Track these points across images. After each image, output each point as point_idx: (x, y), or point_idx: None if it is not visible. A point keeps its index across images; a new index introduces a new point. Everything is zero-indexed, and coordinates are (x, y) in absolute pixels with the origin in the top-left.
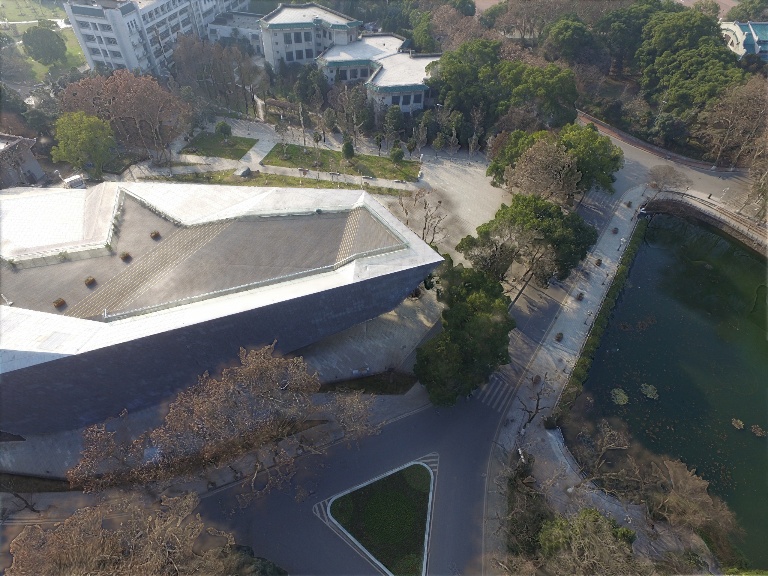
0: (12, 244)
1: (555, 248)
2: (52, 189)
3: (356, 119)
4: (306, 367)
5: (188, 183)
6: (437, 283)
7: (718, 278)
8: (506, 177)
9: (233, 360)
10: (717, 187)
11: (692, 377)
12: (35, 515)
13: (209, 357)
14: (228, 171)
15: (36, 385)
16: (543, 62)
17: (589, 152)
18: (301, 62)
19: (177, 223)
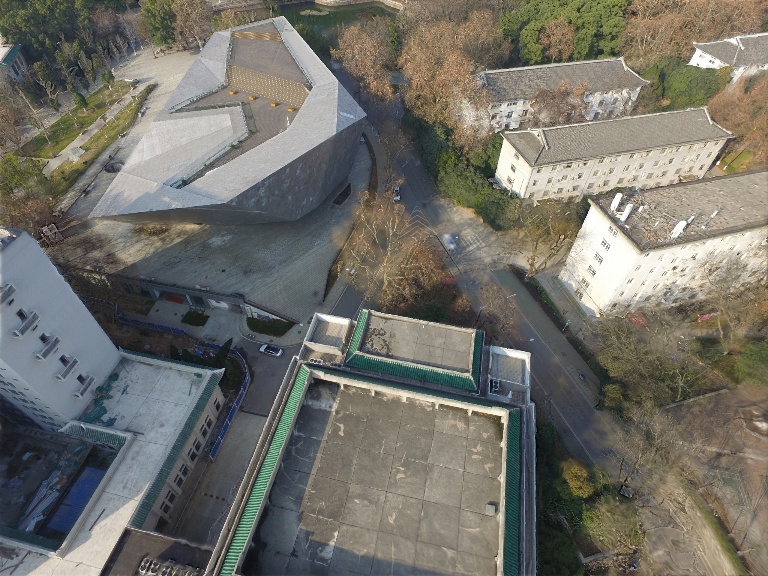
0: (227, 140)
1: None
2: (111, 188)
3: None
4: None
5: (82, 178)
6: None
7: None
8: None
9: None
10: None
11: None
12: (388, 174)
13: None
14: (56, 173)
15: None
16: None
17: None
18: None
19: (223, 86)
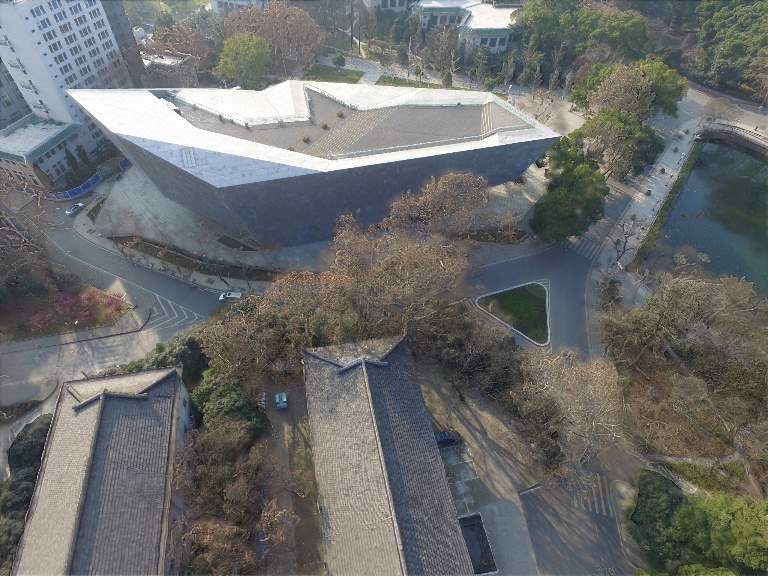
0: (240, 115)
1: (634, 148)
2: None
3: (453, 55)
4: None
5: None
6: (544, 166)
7: (760, 188)
8: (589, 99)
9: None
10: (763, 122)
11: (737, 251)
12: None
13: (391, 196)
14: None
15: (292, 195)
16: (617, 10)
17: (660, 80)
18: (394, 10)
19: (354, 108)
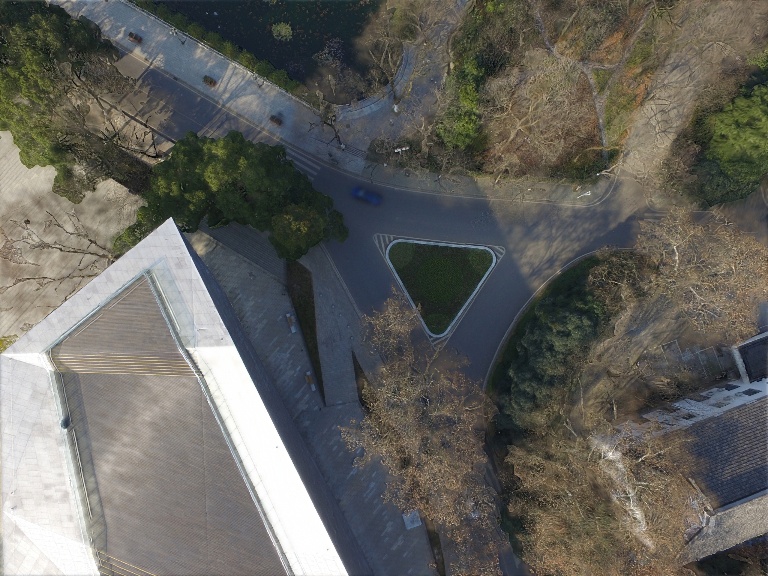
0: None
1: (73, 51)
2: None
3: None
4: (394, 381)
5: None
6: None
7: None
8: None
9: (316, 474)
10: None
11: None
12: None
13: None
14: None
15: None
16: None
17: None
18: None
19: None
